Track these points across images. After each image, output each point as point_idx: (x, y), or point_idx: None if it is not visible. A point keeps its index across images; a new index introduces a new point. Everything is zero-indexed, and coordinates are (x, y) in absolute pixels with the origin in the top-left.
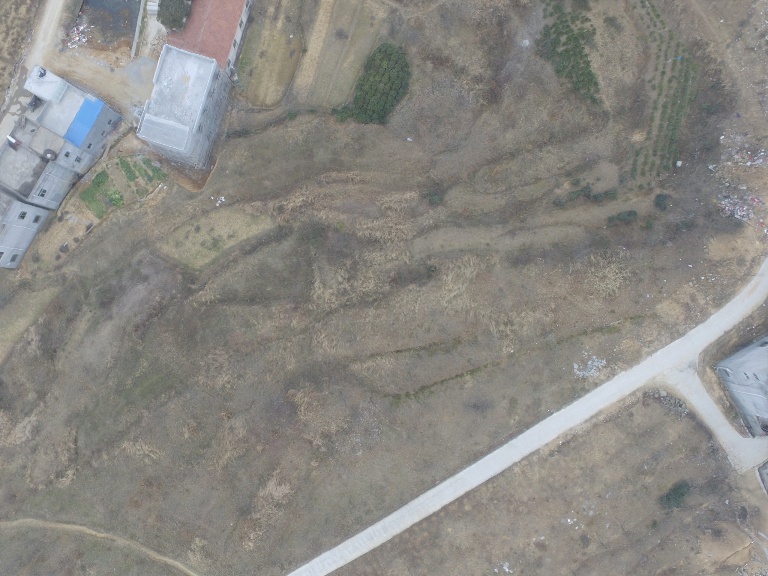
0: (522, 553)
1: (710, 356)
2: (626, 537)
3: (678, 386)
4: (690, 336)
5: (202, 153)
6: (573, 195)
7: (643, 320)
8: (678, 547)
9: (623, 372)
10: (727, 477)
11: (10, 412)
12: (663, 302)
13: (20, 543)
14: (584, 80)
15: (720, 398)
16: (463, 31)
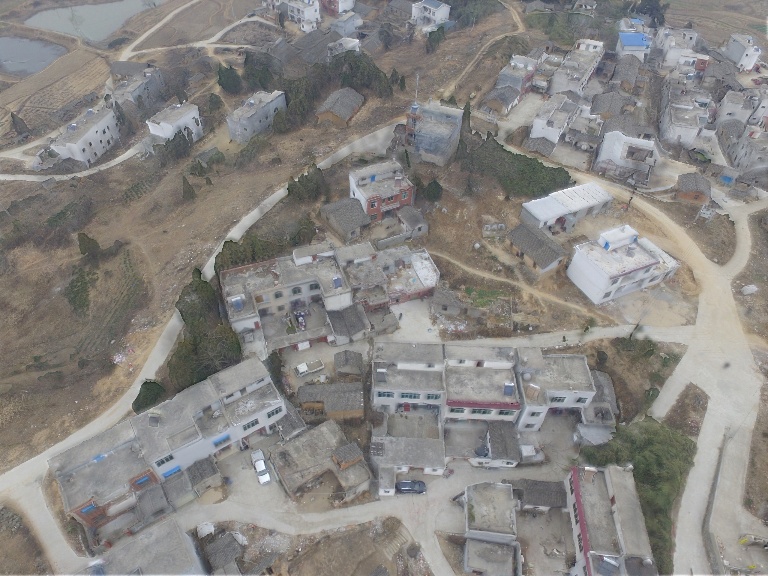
0: None
1: None
2: None
3: (19, 501)
4: (45, 453)
5: None
6: (26, 366)
7: (16, 445)
8: None
9: None
10: None
11: None
12: (42, 430)
13: None
14: (81, 304)
15: (60, 512)
16: (26, 287)
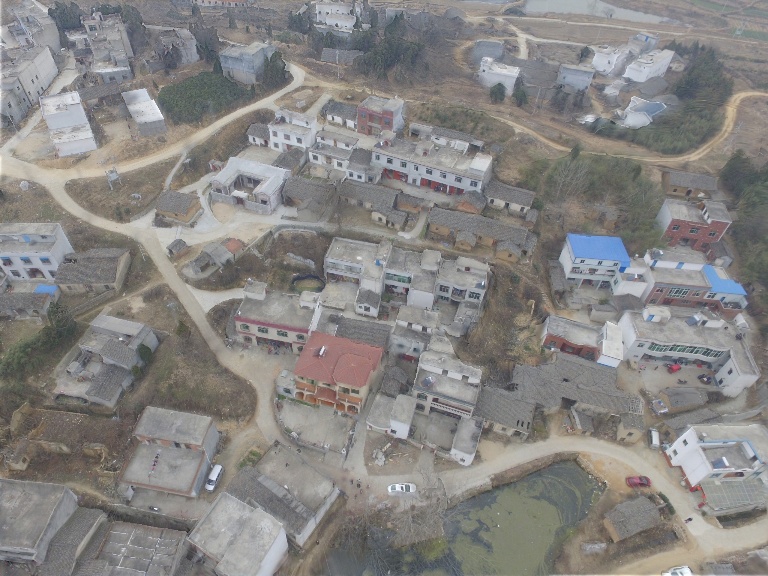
0: None
1: None
2: None
3: None
4: None
5: None
6: None
7: None
8: None
9: None
10: None
11: None
12: None
13: None
14: None
15: None
16: None
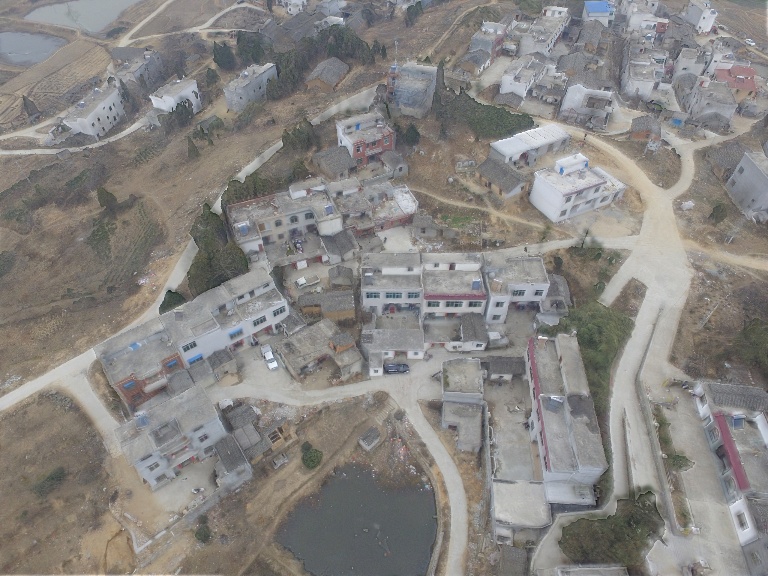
0: None
1: (101, 365)
2: None
3: (69, 388)
4: (87, 353)
5: None
6: (61, 296)
7: (61, 349)
8: (57, 549)
9: (29, 382)
10: (102, 462)
11: None
12: (82, 338)
13: None
14: (103, 248)
15: (104, 395)
16: (52, 240)
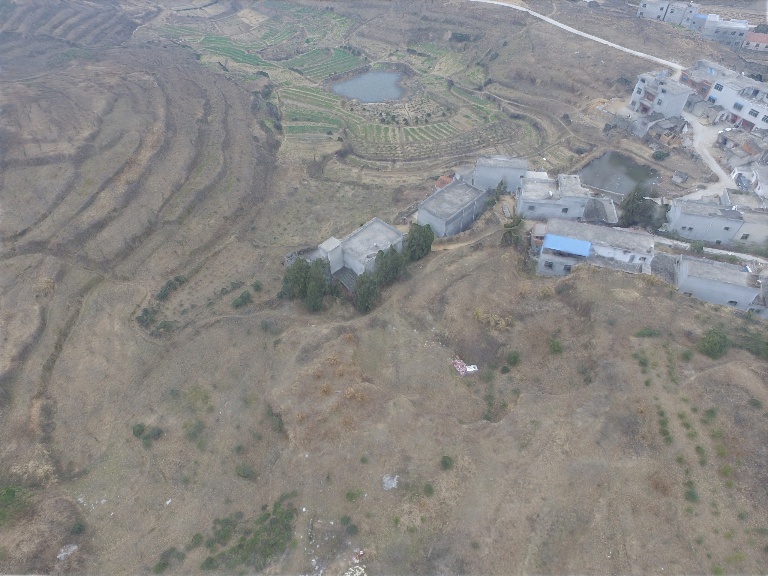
0: (584, 54)
1: None
2: None
3: None
4: None
5: (706, 37)
6: None
7: None
8: None
9: (677, 64)
10: None
11: (588, 6)
12: None
13: (545, 3)
14: None
15: None
16: None
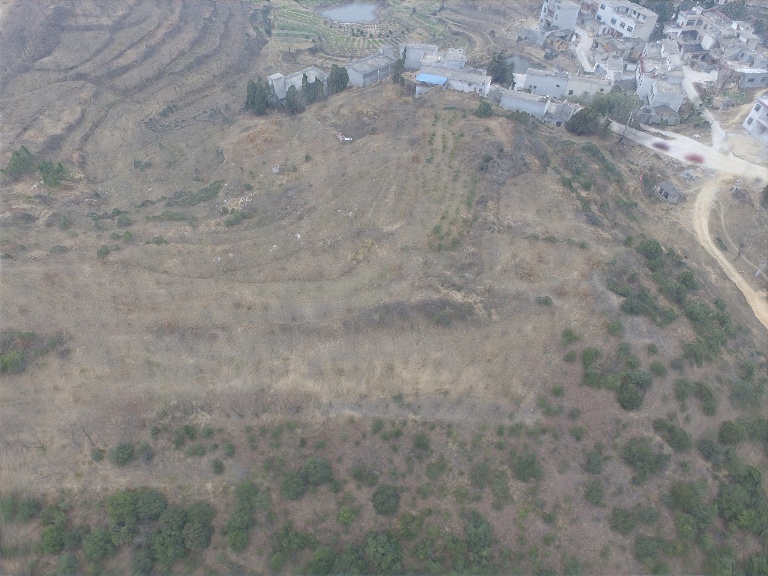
0: None
1: None
2: (526, 3)
3: None
4: None
5: None
6: None
7: None
8: (519, 17)
9: None
10: None
11: None
12: None
13: None
14: None
15: None
16: None
